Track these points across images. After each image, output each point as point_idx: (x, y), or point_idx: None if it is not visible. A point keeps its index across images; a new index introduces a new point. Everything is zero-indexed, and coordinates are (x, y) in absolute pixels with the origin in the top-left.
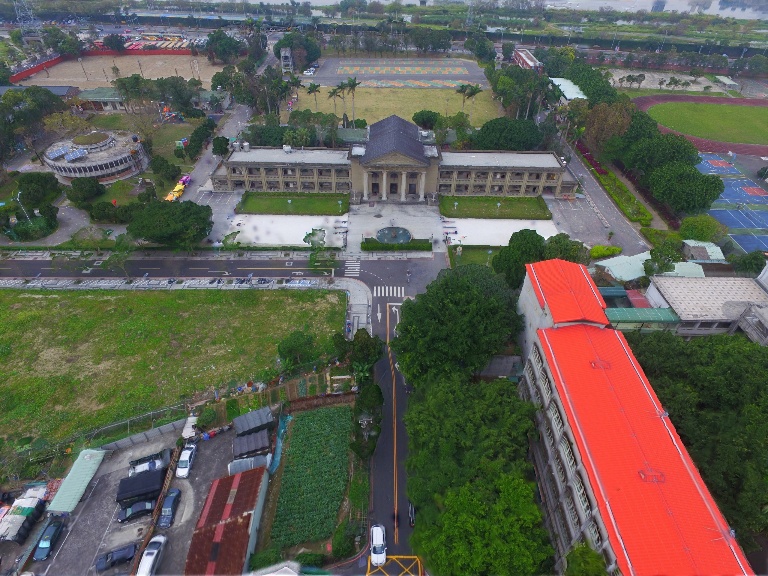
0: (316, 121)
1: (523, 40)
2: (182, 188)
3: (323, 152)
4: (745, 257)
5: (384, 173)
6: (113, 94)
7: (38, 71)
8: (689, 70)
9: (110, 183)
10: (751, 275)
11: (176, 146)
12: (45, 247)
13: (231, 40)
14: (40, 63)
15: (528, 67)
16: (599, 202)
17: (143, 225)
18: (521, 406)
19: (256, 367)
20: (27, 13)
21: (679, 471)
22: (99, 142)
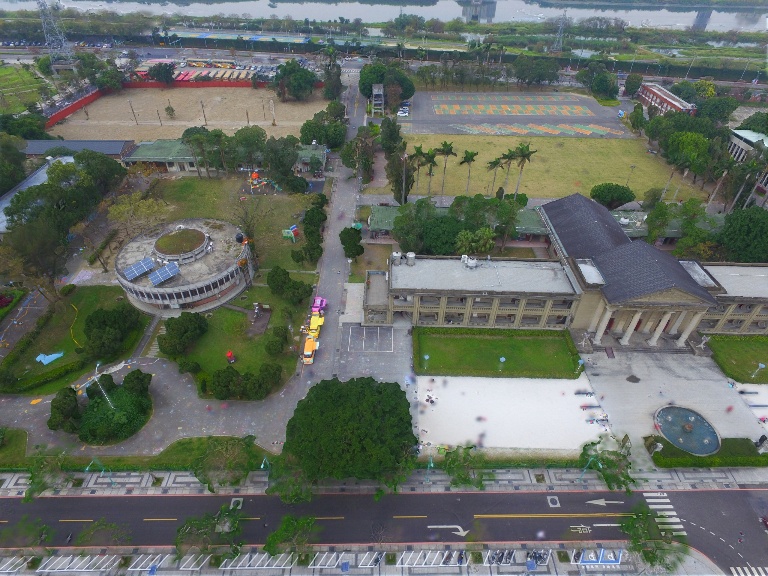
0: (486, 209)
1: (633, 69)
2: (322, 323)
3: (521, 266)
4: None
5: (639, 312)
6: (180, 150)
7: (74, 111)
8: None
9: (210, 308)
10: None
11: (281, 235)
12: (143, 465)
13: (306, 72)
14: (76, 100)
15: (675, 109)
16: None
17: (320, 449)
18: None
19: None
20: (58, 37)
21: None
22: (194, 248)
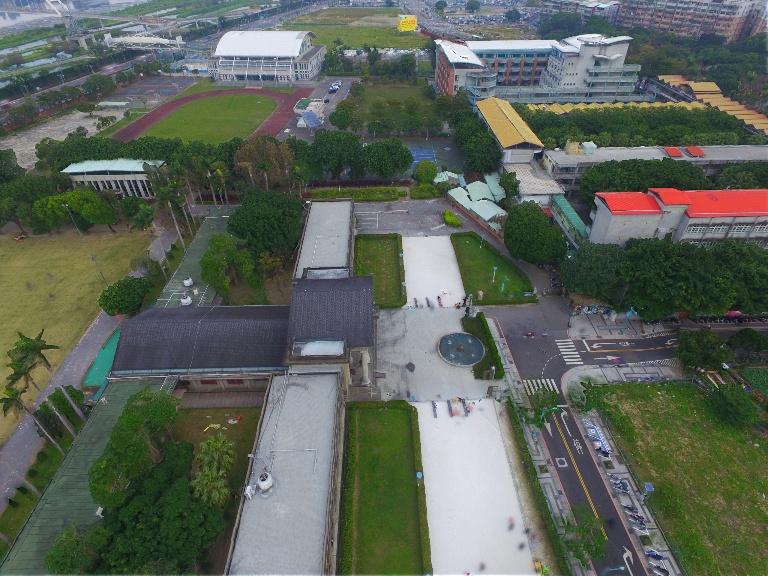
0: None
1: None
2: None
3: (274, 419)
4: (479, 161)
5: None
6: None
7: None
8: (56, 111)
9: None
10: (493, 166)
11: None
12: None
13: None
14: None
15: None
16: (362, 208)
17: None
18: (736, 243)
19: (762, 458)
20: None
21: (761, 191)
22: None
